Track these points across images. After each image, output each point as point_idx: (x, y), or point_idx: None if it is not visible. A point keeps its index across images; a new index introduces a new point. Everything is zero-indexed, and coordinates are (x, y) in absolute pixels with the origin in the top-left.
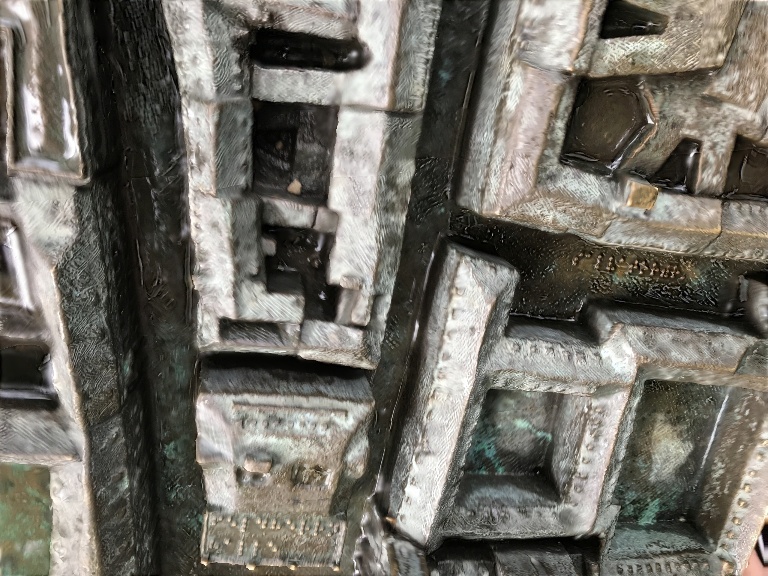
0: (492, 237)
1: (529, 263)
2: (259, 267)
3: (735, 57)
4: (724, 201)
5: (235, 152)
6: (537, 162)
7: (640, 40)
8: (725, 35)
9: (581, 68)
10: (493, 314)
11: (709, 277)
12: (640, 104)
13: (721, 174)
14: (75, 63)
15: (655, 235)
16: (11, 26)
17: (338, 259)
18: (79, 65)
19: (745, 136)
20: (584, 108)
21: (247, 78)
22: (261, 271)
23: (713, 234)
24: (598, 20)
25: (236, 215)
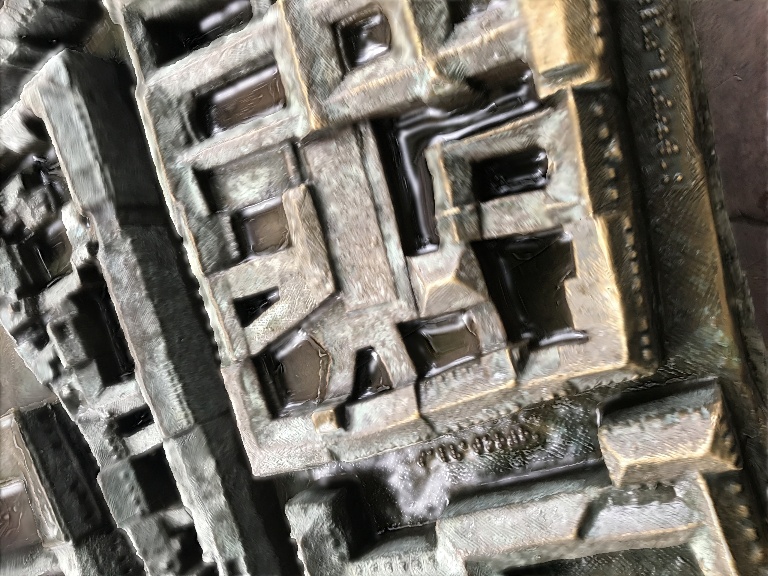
0: (346, 469)
1: (386, 478)
2: (170, 561)
3: (347, 275)
4: (426, 381)
5: (125, 495)
6: (251, 430)
7: (269, 312)
8: (321, 271)
9: (243, 354)
10: (306, 551)
11: (567, 424)
12: (312, 345)
13: (406, 361)
14: (43, 484)
15: (375, 441)
16: (21, 478)
17: (201, 541)
18: (47, 484)
19: (405, 321)
20: (289, 365)
21: (122, 448)
22: (175, 563)
23: (417, 420)
24: (235, 319)
25: (137, 534)
